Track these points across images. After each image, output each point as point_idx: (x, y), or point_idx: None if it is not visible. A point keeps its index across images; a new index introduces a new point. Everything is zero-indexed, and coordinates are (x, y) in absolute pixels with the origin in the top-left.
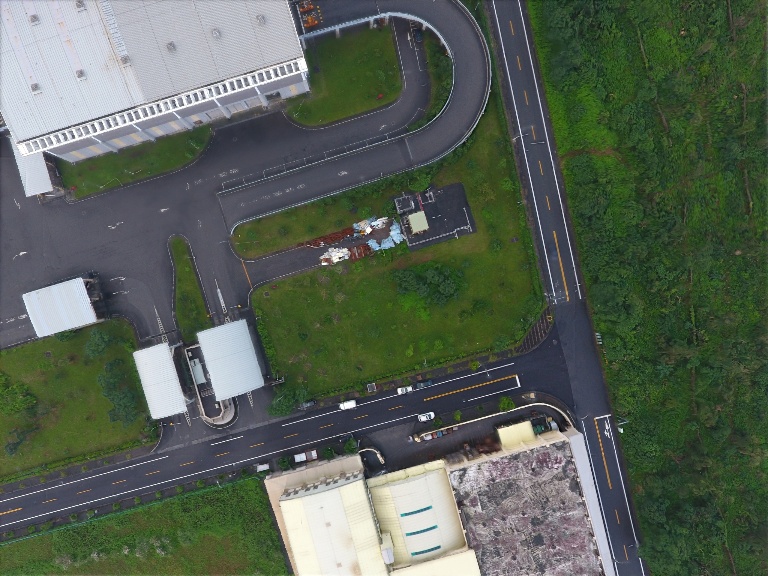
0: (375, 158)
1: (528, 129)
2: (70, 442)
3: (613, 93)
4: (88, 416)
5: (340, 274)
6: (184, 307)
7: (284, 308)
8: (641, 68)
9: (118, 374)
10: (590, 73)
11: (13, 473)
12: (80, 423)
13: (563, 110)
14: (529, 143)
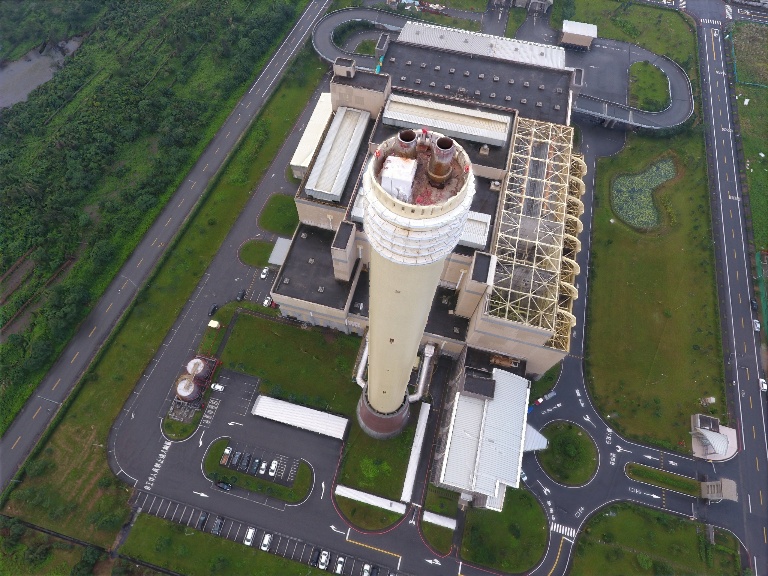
0: (394, 23)
1: (318, 8)
2: (602, 3)
3: (273, 1)
4: (588, 6)
5: (439, 1)
6: (520, 19)
7: (472, 2)
8: (252, 5)
9: (564, 6)
10: (279, 3)
11: (635, 4)
12: (593, 6)
13: (298, 6)
14: (321, 4)
